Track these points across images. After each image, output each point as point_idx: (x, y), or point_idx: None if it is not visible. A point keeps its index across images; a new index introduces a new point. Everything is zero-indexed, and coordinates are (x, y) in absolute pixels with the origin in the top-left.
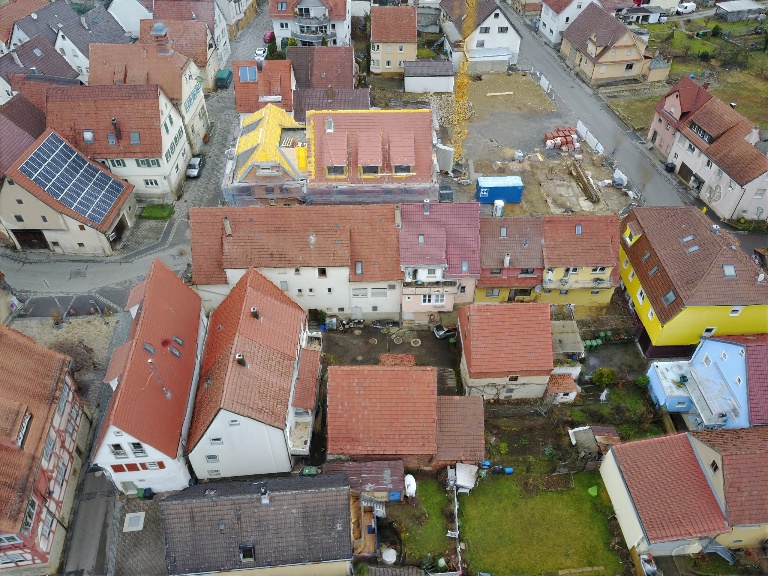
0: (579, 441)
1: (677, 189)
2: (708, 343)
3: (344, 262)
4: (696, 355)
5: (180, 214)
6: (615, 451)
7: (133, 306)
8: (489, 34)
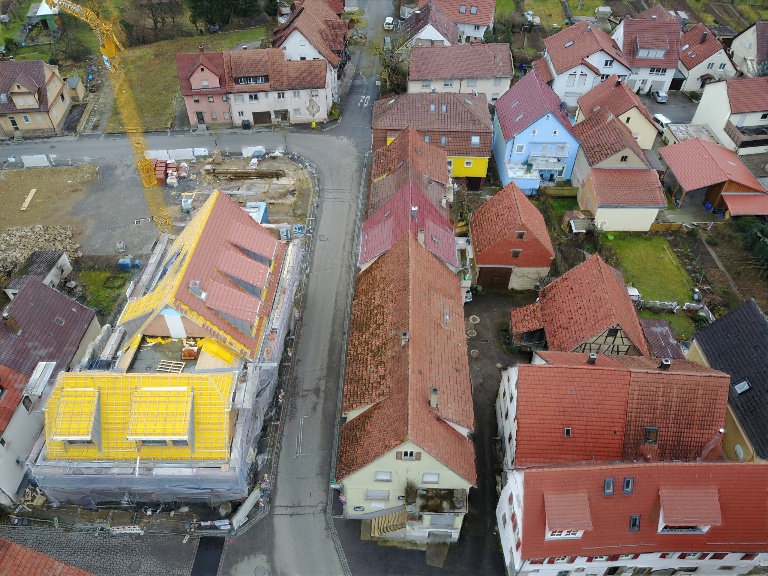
0: (584, 228)
1: (275, 131)
2: (518, 137)
3: (460, 308)
4: (512, 153)
5: None
6: (603, 205)
7: (588, 514)
8: None
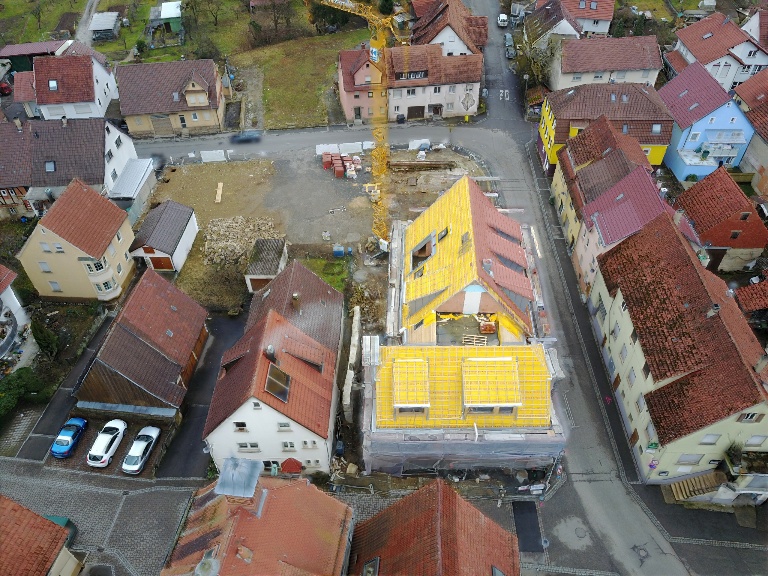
0: None
1: (429, 125)
2: (696, 125)
3: (724, 284)
4: None
5: (534, 567)
6: None
7: None
8: (113, 157)
